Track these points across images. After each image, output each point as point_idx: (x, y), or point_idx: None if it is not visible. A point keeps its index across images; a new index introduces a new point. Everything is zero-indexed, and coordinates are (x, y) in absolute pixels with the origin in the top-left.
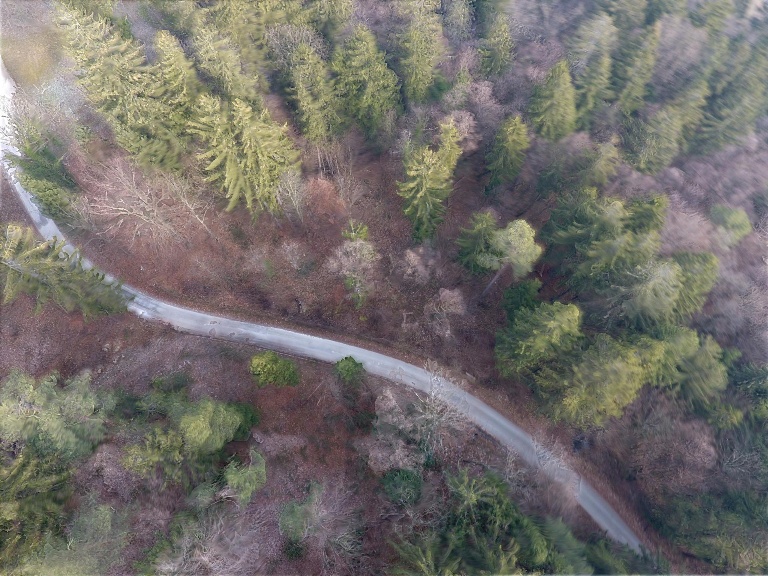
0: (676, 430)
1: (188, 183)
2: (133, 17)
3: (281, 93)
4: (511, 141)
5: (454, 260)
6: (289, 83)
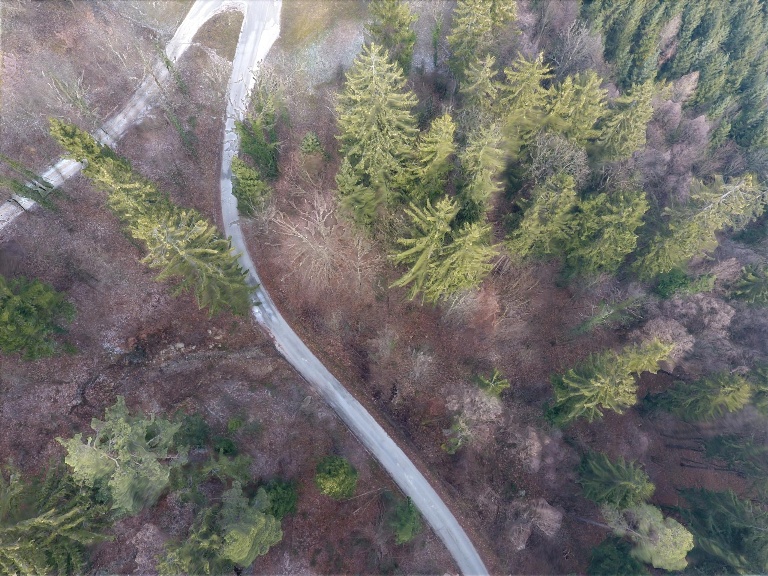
0: None
1: (370, 230)
2: None
3: (505, 178)
4: (720, 400)
5: (566, 439)
6: (520, 177)
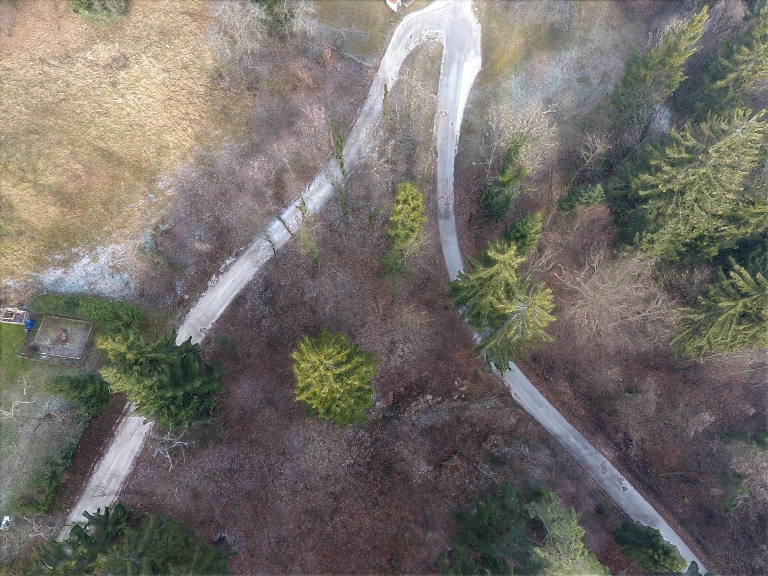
0: None
1: None
2: (602, 47)
3: None
4: None
5: None
6: None
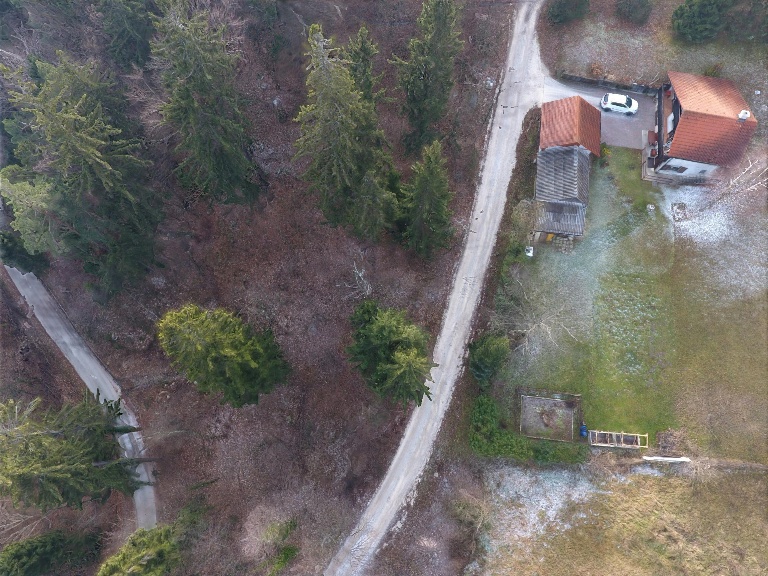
0: None
1: None
2: None
3: None
4: None
5: None
6: None
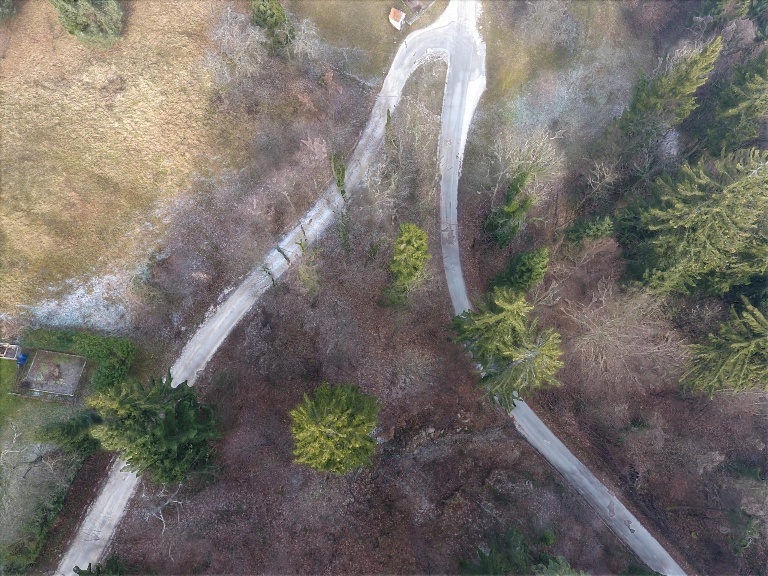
0: None
1: None
2: (608, 65)
3: None
4: None
5: None
6: None
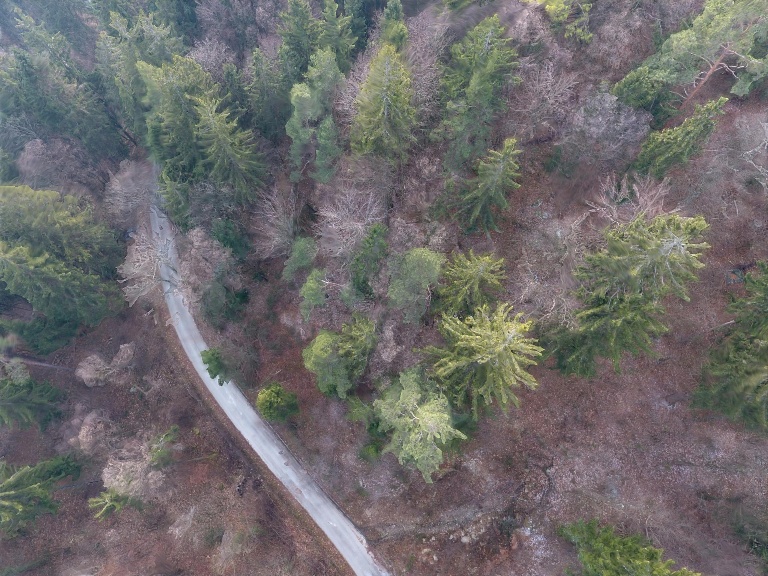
0: (40, 170)
1: None
2: None
3: None
4: None
5: None
6: None
